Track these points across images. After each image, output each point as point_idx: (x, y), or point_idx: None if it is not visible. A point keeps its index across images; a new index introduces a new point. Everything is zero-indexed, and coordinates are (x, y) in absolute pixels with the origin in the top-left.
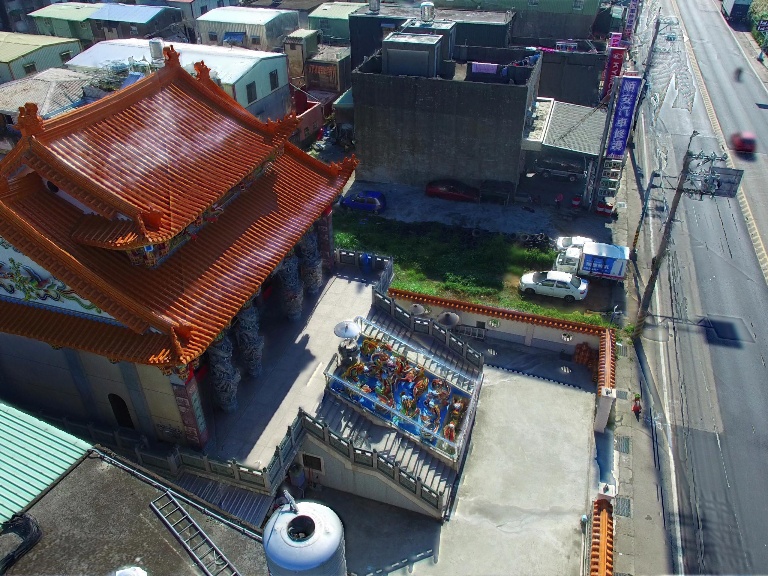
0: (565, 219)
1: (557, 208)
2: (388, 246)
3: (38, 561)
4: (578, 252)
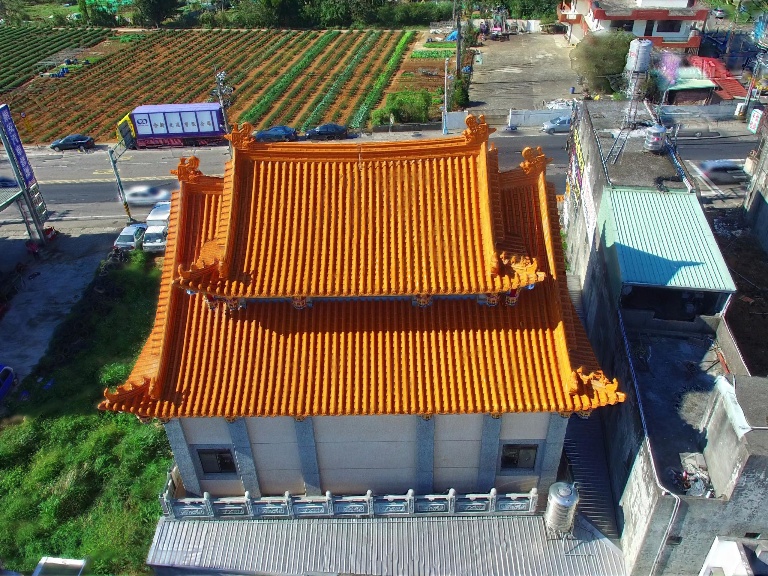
0: (58, 257)
1: (37, 259)
2: (113, 350)
3: (664, 175)
4: (157, 227)
